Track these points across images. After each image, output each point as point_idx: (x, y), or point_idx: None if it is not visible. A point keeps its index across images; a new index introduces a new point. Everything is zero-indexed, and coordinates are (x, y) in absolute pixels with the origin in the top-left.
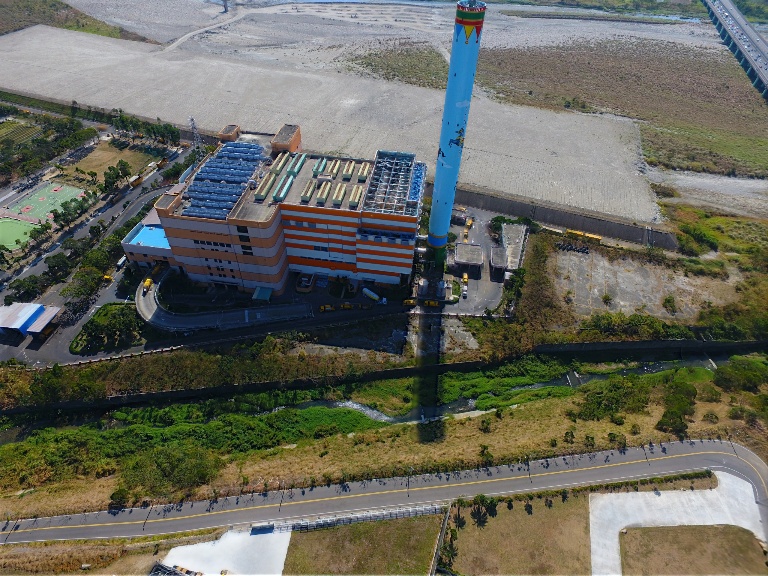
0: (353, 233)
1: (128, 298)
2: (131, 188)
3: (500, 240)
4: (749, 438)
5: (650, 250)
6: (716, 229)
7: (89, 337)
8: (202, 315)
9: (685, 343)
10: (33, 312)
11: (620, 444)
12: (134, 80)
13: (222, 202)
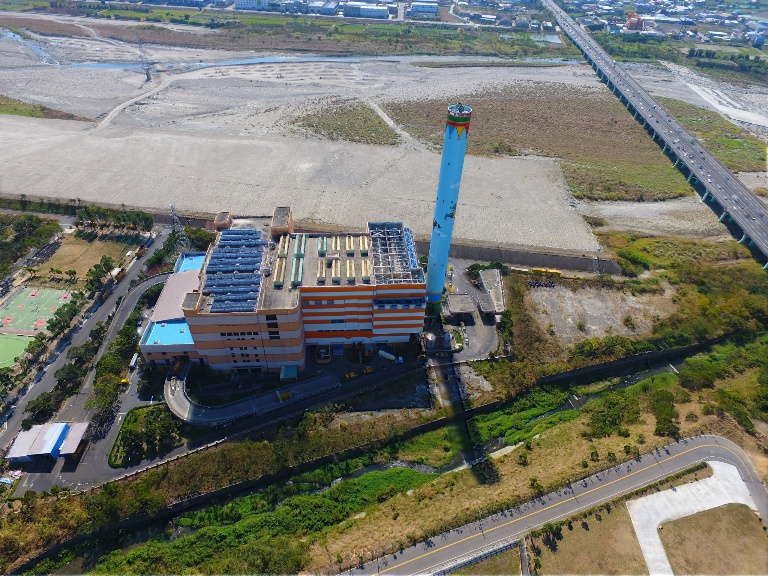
0: (368, 304)
1: (153, 399)
2: (115, 282)
3: (480, 286)
4: (723, 429)
5: (601, 277)
6: (643, 250)
7: (126, 447)
8: (237, 404)
9: (650, 355)
10: (60, 432)
11: (635, 454)
12: (77, 163)
13: (245, 294)
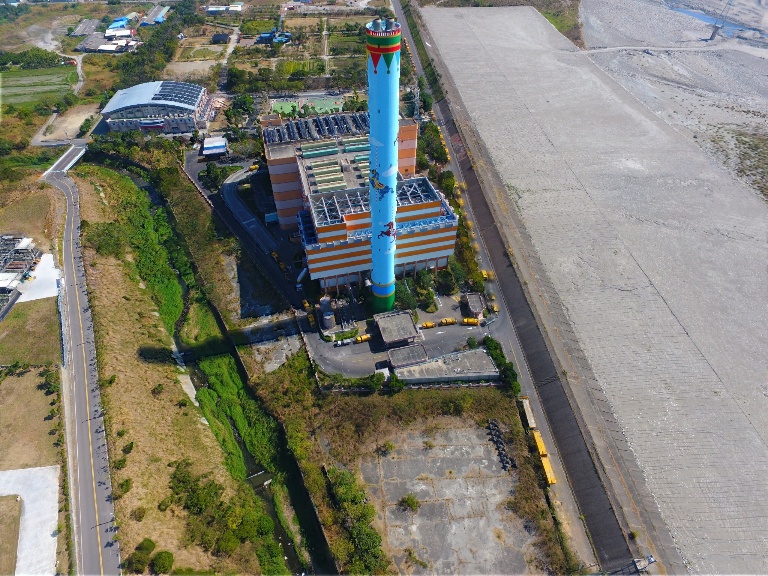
0: None
1: None
2: None
3: None
4: None
5: None
6: None
7: None
8: (240, 201)
9: None
10: (217, 145)
11: None
12: (505, 64)
13: None
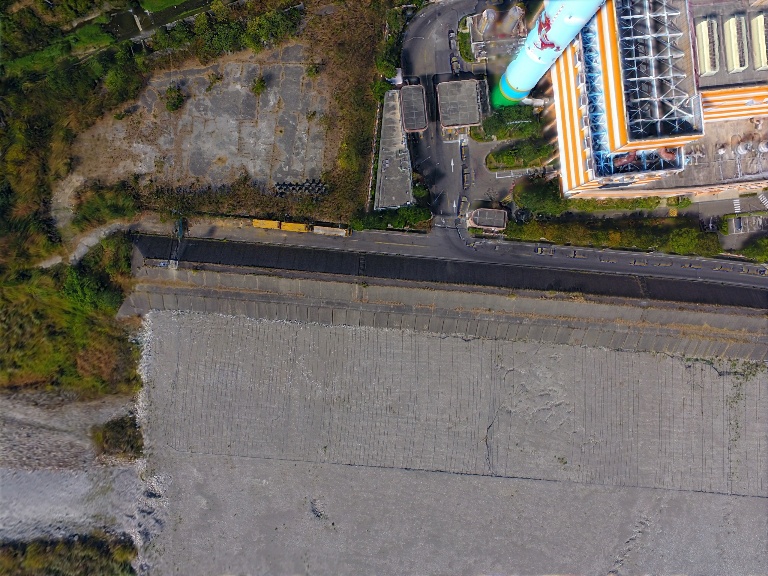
0: None
1: None
2: None
3: None
4: None
5: None
6: (56, 332)
7: None
8: None
9: None
10: None
11: None
12: None
13: None
